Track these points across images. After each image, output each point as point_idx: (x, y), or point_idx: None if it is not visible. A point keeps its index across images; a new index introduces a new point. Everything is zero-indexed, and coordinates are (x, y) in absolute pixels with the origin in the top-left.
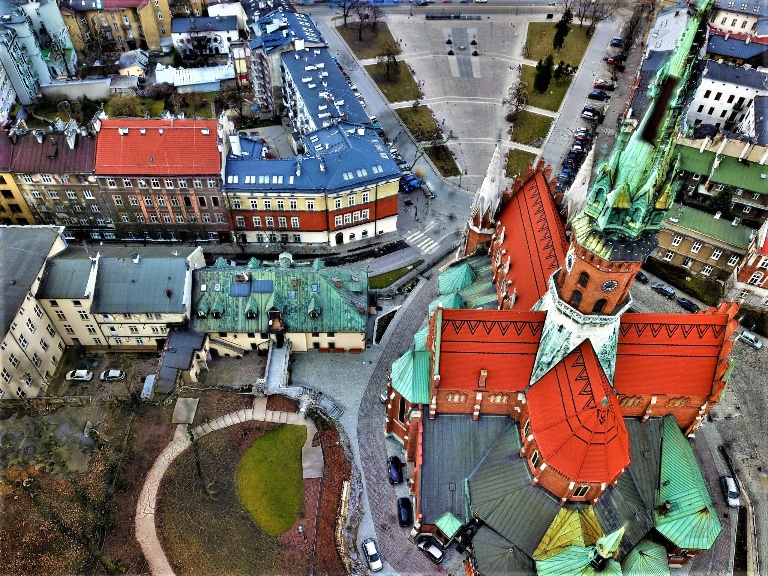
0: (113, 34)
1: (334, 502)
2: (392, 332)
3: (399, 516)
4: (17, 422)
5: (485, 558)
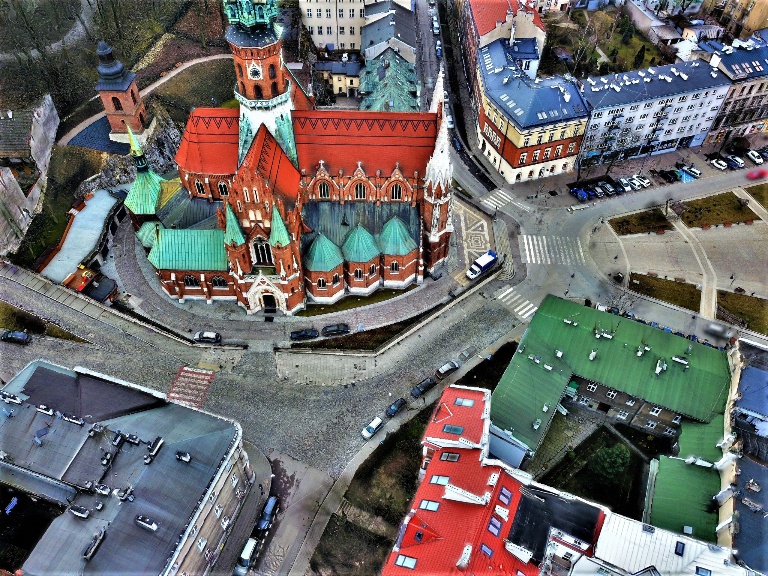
0: (735, 11)
1: None
2: None
3: None
4: (290, 20)
5: None
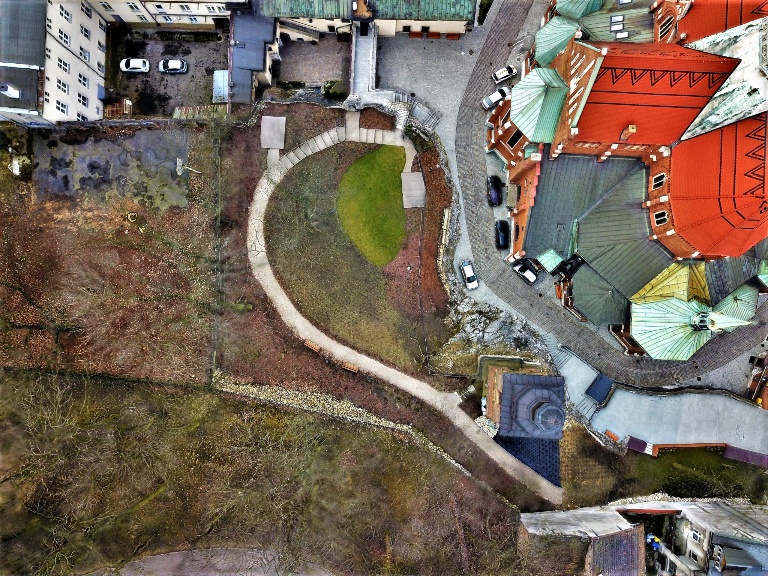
0: None
1: (436, 231)
2: (499, 8)
3: (497, 240)
4: (97, 147)
5: (583, 295)
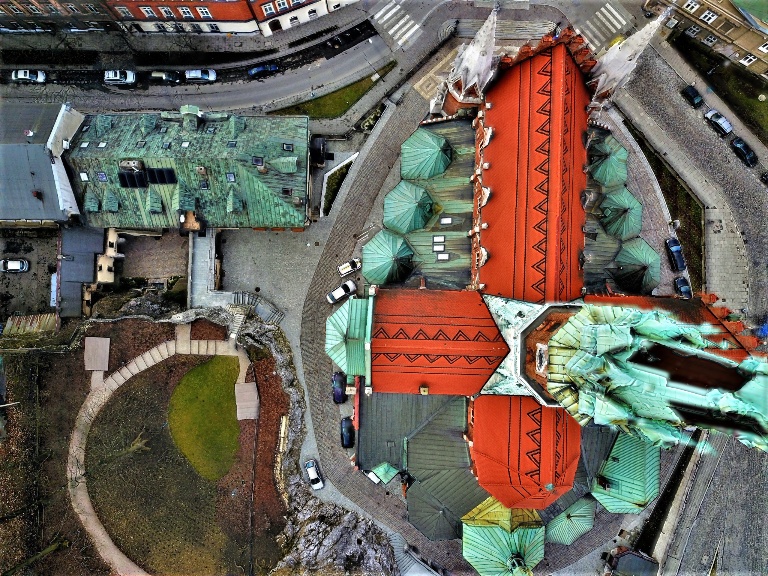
0: None
1: (272, 441)
2: (344, 198)
3: (342, 439)
4: None
5: (416, 512)
